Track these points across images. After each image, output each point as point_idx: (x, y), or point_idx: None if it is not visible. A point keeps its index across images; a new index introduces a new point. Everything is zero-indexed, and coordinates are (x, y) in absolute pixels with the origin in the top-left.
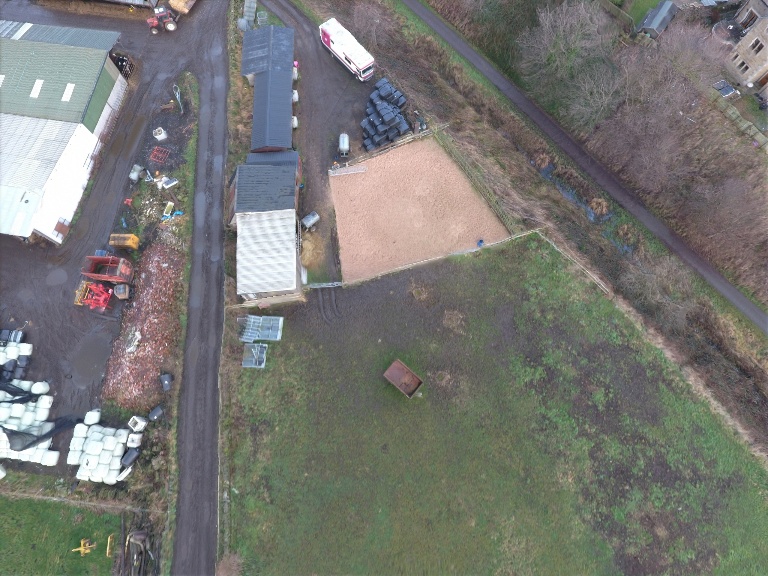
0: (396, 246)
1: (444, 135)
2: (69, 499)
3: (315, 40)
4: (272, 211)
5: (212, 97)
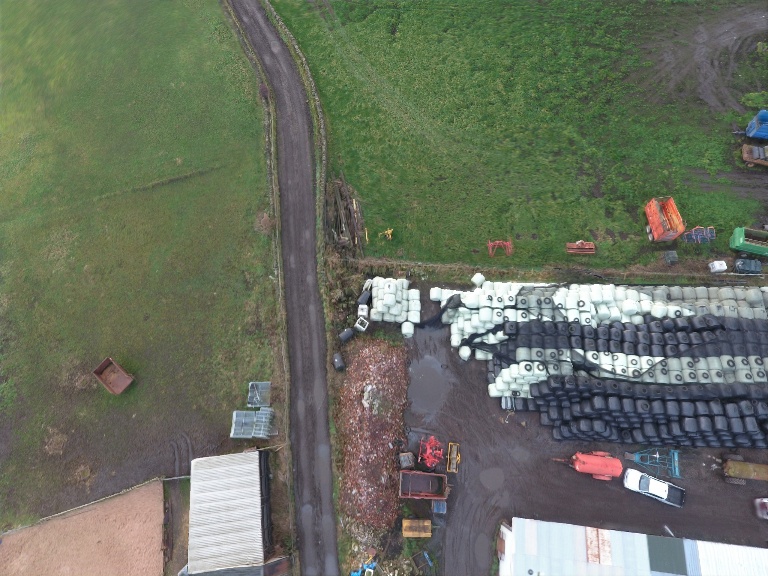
0: (98, 537)
1: None
2: (411, 265)
3: None
4: (217, 570)
5: None
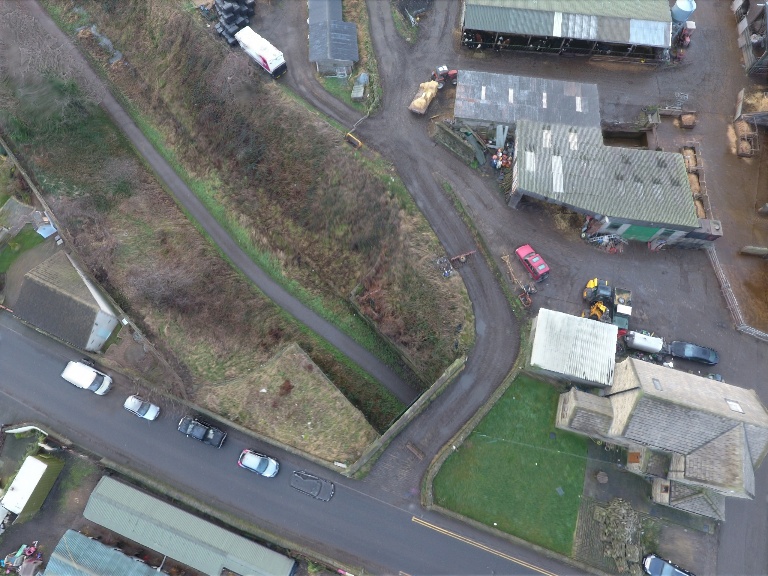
0: None
1: (188, 8)
2: None
3: (295, 78)
4: None
5: (383, 21)
